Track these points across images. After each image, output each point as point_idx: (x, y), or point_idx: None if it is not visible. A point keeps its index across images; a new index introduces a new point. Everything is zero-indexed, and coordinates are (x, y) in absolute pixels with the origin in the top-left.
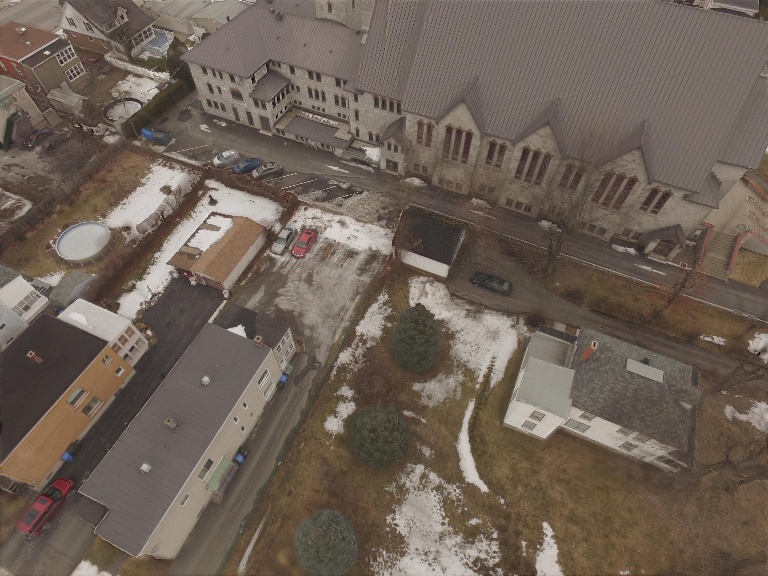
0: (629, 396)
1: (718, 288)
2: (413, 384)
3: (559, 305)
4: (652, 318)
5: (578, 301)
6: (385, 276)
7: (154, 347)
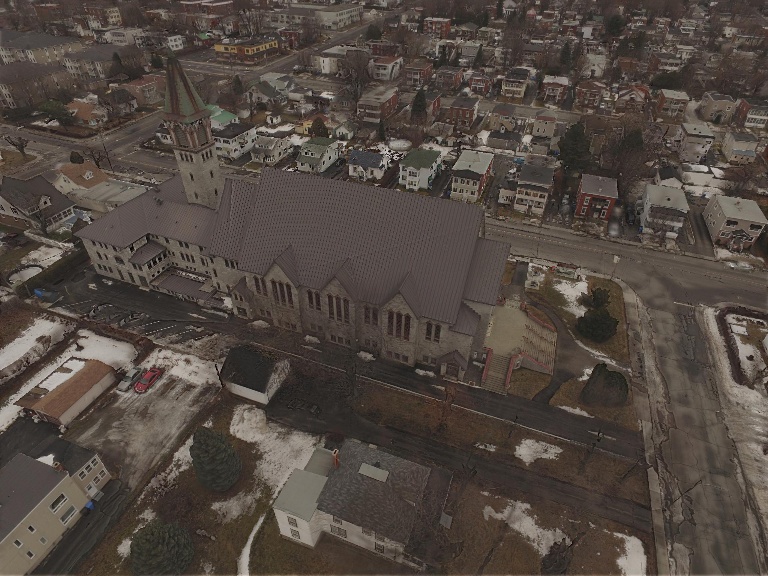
0: (361, 496)
1: (498, 402)
2: (213, 504)
3: (359, 424)
4: (437, 431)
5: (377, 419)
6: (214, 406)
7: None
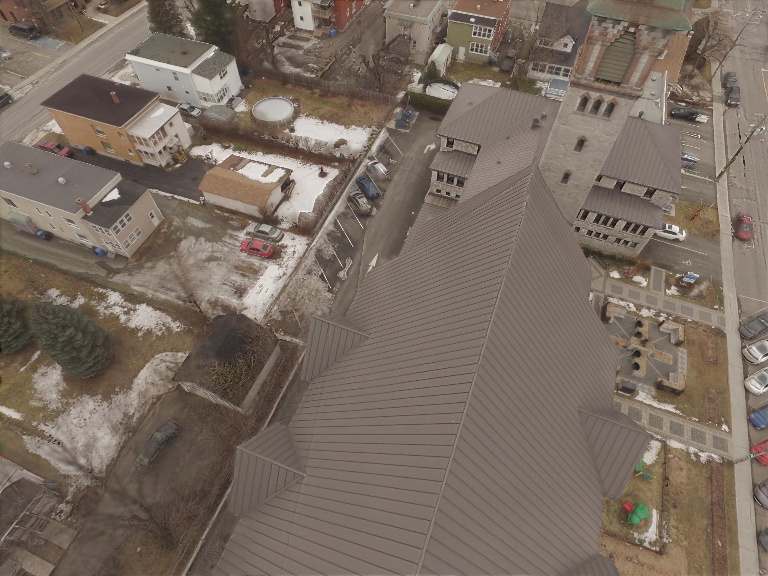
0: None
1: None
2: None
3: (103, 544)
4: None
5: None
6: None
7: (163, 171)
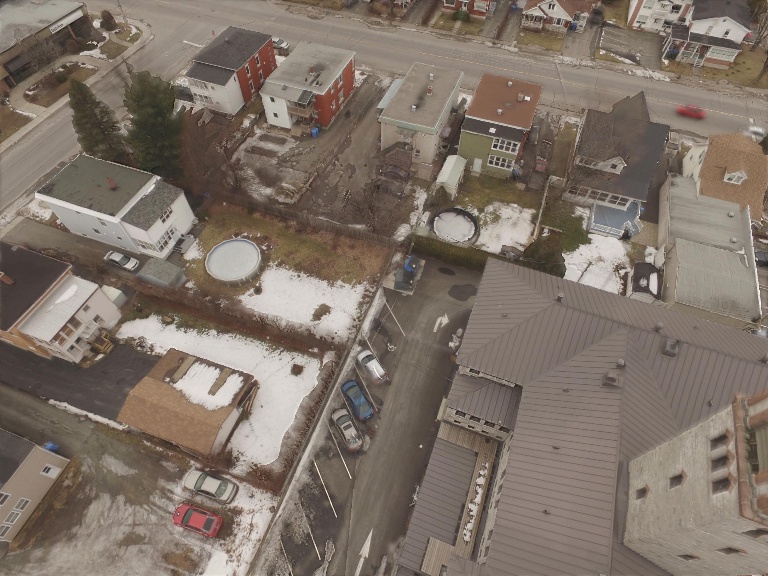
0: None
1: None
2: None
3: None
4: None
5: None
6: None
7: (78, 367)
